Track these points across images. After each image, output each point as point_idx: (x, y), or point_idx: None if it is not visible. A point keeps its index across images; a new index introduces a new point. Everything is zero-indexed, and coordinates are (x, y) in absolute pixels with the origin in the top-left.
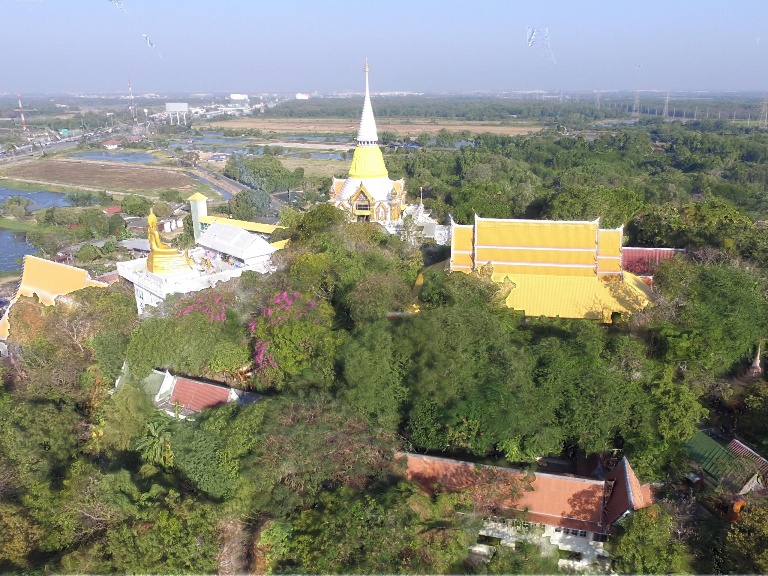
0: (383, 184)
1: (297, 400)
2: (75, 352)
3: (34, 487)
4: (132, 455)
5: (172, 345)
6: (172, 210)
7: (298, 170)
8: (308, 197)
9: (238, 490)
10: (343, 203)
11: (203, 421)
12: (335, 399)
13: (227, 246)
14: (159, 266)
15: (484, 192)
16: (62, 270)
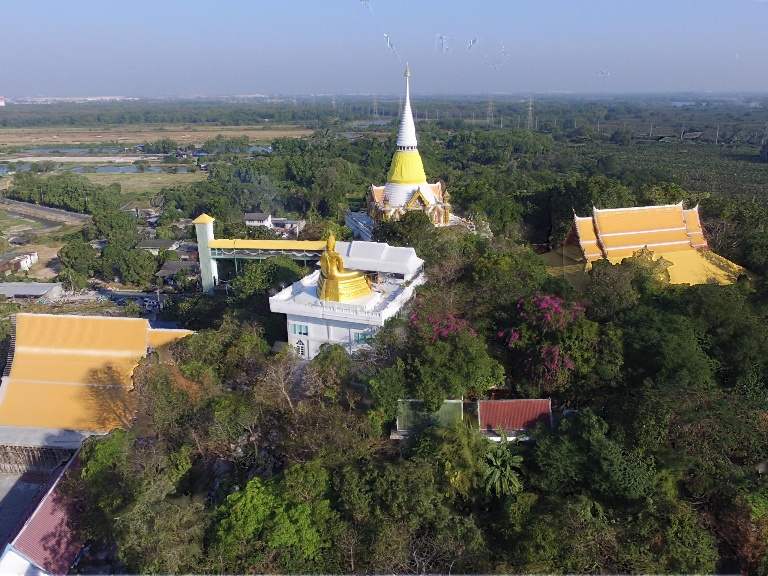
0: (428, 188)
1: (671, 388)
2: (276, 408)
3: (538, 537)
4: (476, 492)
5: (474, 368)
6: (8, 244)
7: (113, 186)
8: (171, 214)
9: (662, 484)
10: (400, 210)
11: (583, 431)
12: (630, 387)
13: (376, 263)
14: (344, 293)
15: (476, 190)
16: (98, 324)
